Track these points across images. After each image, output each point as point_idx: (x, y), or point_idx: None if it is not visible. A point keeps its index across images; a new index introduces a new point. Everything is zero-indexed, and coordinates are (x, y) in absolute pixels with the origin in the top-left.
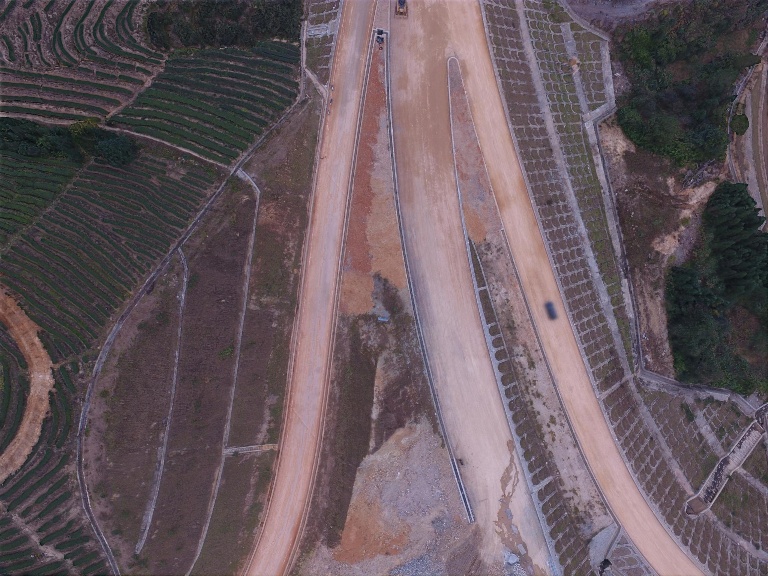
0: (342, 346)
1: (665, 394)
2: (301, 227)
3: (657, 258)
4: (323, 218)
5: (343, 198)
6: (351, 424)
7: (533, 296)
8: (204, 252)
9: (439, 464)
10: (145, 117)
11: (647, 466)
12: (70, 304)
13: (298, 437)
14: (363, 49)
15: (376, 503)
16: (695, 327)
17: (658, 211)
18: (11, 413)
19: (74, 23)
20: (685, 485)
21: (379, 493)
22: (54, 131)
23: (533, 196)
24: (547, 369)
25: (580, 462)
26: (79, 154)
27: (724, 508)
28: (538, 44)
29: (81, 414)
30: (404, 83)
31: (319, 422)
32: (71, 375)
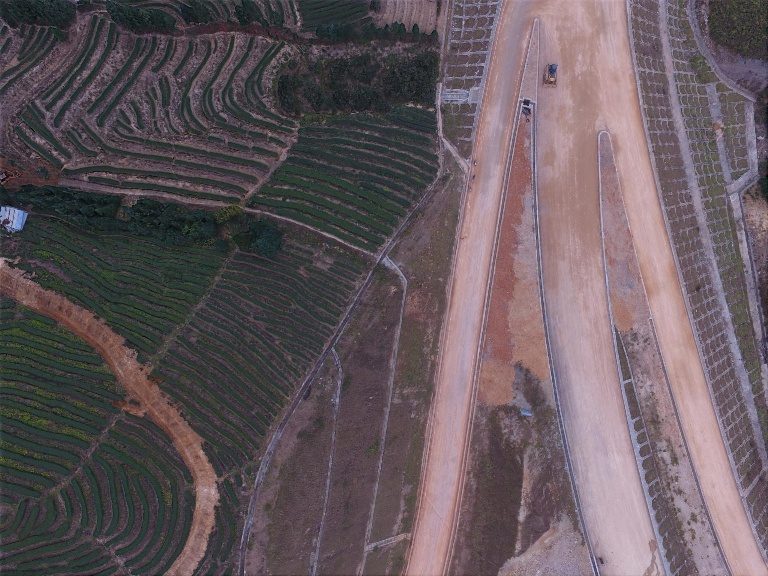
0: (480, 437)
1: None
2: (439, 312)
3: None
4: (462, 302)
5: (483, 281)
6: (492, 521)
7: (679, 389)
8: (356, 351)
9: (579, 562)
10: (286, 198)
11: None
12: (230, 412)
13: (431, 526)
14: (508, 120)
15: None
16: None
17: None
18: (178, 529)
19: (202, 87)
20: None
21: None
22: (199, 218)
23: (684, 284)
24: (690, 465)
25: (719, 561)
26: (226, 244)
27: None
28: (687, 111)
29: (244, 527)
30: (551, 159)
31: (453, 513)
32: (234, 488)
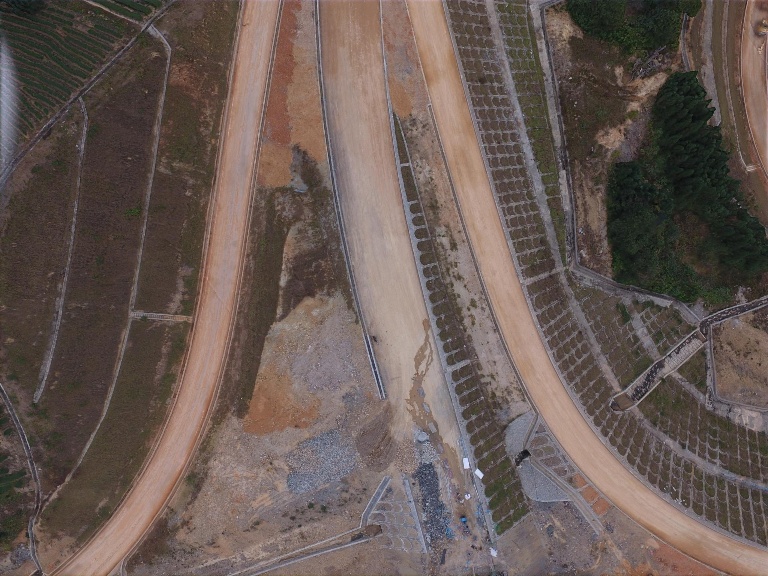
0: (259, 219)
1: (599, 291)
2: (220, 96)
3: (599, 151)
4: (244, 88)
5: (265, 68)
6: (262, 295)
7: (459, 176)
8: (107, 104)
9: (352, 340)
10: None
11: (571, 357)
12: None
13: (213, 311)
14: None
15: (286, 375)
16: (631, 219)
17: (603, 101)
18: None
19: None
20: (612, 381)
21: (289, 365)
22: None
23: (463, 71)
24: (470, 251)
25: (500, 347)
26: None
27: (653, 407)
28: None
29: None
30: None
31: (234, 296)
32: None
